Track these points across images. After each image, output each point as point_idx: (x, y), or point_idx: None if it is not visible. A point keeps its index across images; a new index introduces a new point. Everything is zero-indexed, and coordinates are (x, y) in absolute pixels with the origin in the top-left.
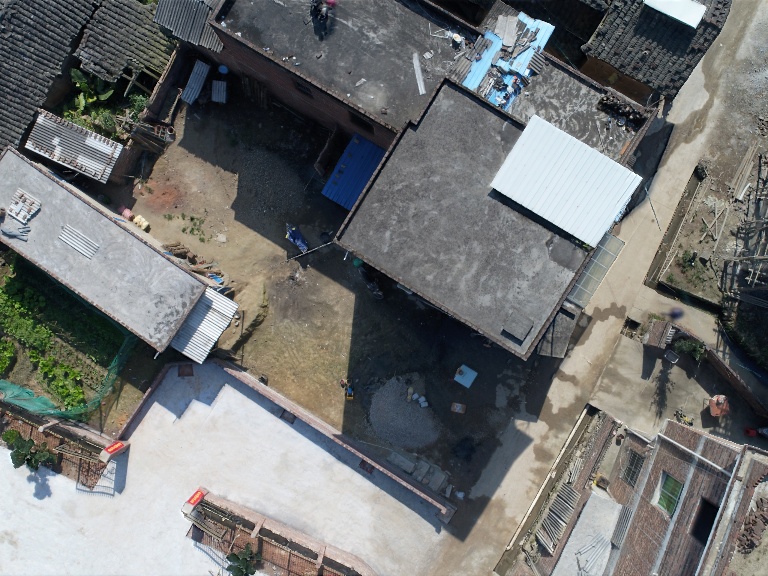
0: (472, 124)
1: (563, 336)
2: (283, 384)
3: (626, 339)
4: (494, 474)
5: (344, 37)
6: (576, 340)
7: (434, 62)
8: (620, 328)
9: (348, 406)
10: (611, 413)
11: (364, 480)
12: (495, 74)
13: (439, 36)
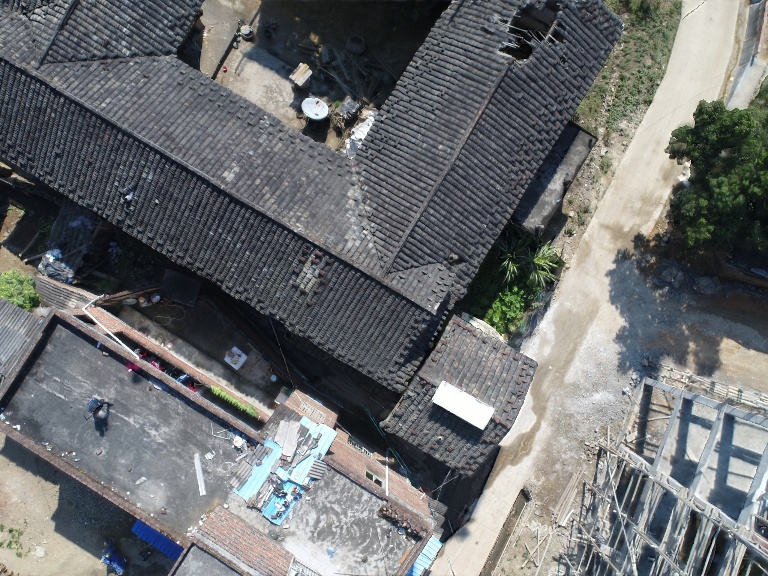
0: None
1: None
2: None
3: None
4: None
5: (125, 434)
6: None
7: (216, 463)
8: None
9: None
10: None
11: None
12: (275, 481)
13: (221, 437)
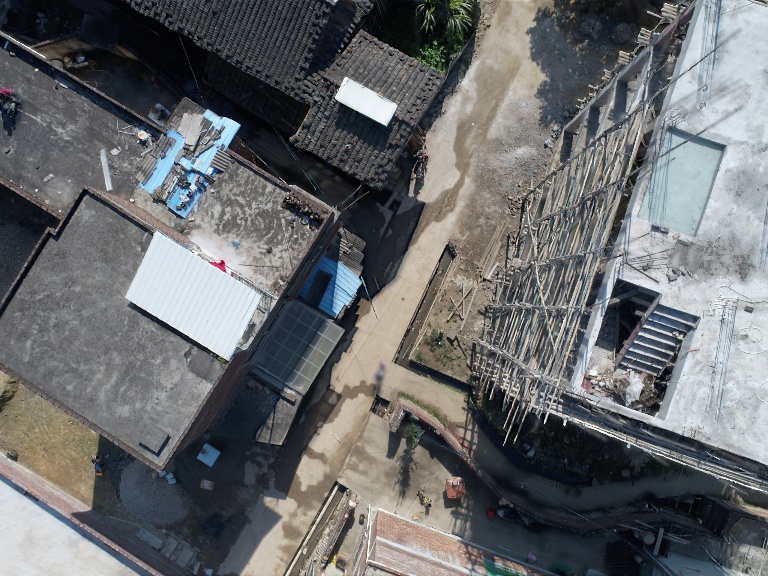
0: (113, 234)
1: (283, 422)
2: (33, 459)
3: (374, 417)
4: (243, 551)
5: (33, 132)
6: (325, 418)
7: (121, 158)
8: (369, 406)
9: (98, 482)
10: (357, 491)
11: (110, 557)
12: (179, 172)
13: (126, 133)
